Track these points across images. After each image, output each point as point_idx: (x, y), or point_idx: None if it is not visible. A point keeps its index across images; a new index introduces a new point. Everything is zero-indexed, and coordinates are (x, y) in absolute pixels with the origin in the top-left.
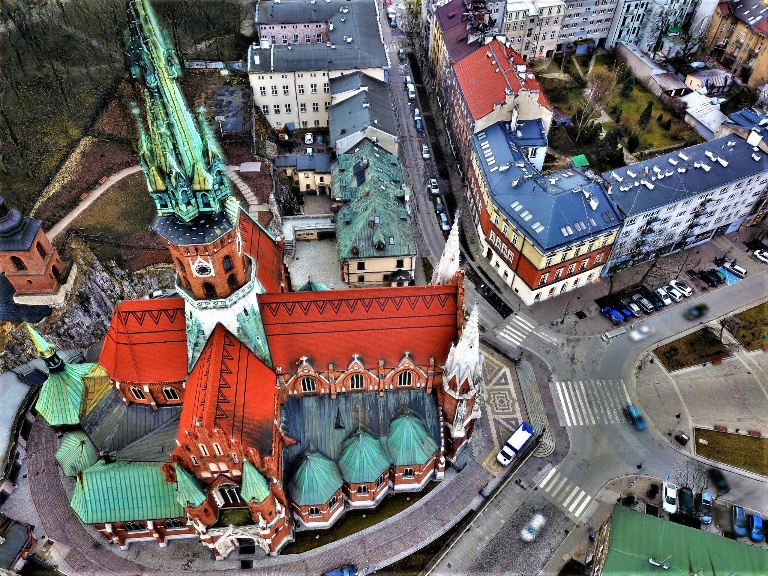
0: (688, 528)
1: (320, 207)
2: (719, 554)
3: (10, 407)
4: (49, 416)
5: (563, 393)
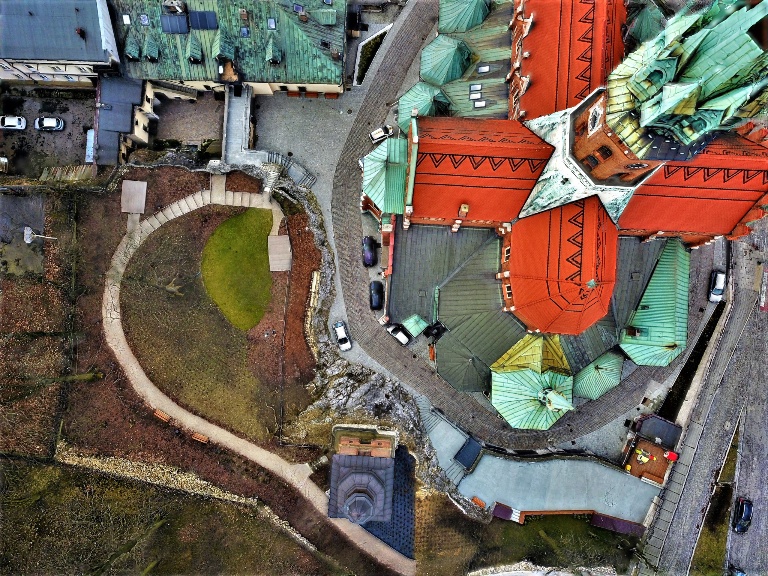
0: None
1: (186, 117)
2: None
3: (508, 473)
4: (564, 410)
5: None
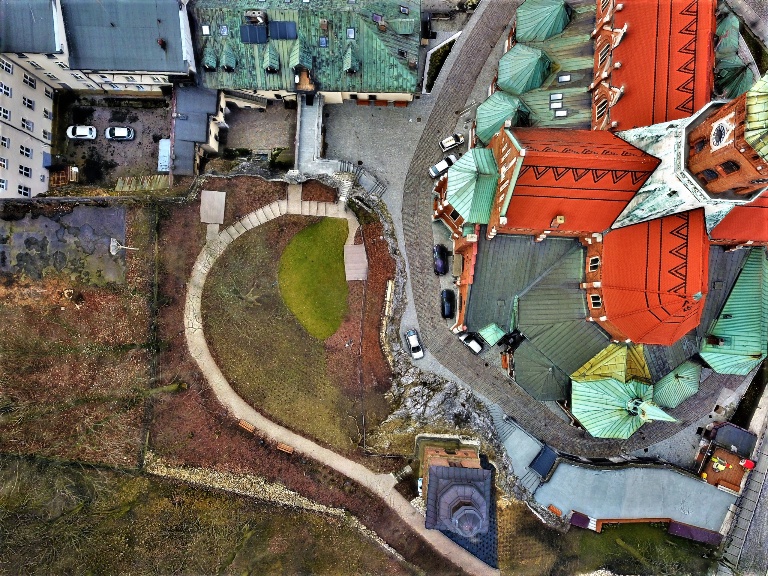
0: None
1: (256, 126)
2: None
3: (583, 481)
4: None
5: None
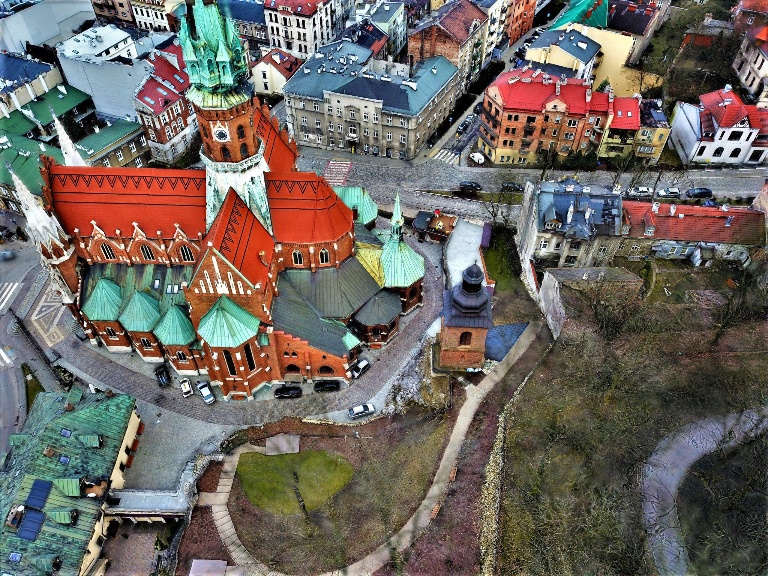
0: (6, 182)
1: (124, 571)
2: (3, 169)
3: None
4: None
5: None
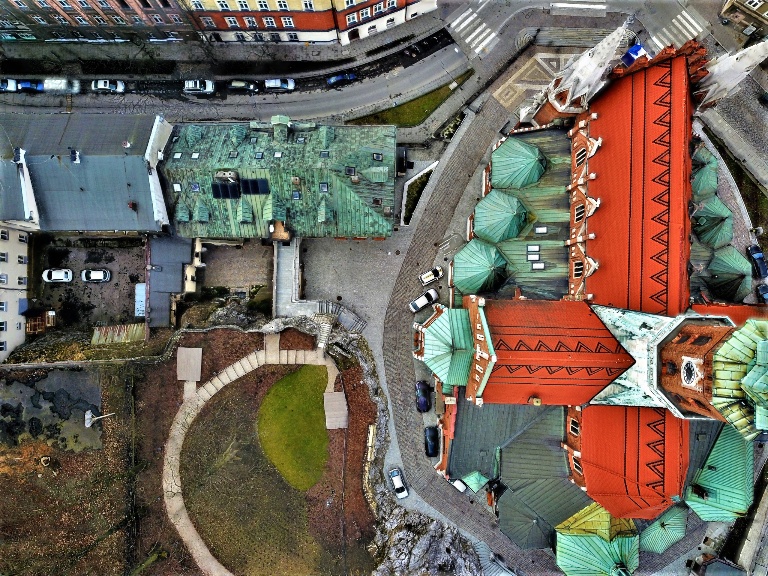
0: None
1: (233, 263)
2: None
3: None
4: None
5: (566, 2)
